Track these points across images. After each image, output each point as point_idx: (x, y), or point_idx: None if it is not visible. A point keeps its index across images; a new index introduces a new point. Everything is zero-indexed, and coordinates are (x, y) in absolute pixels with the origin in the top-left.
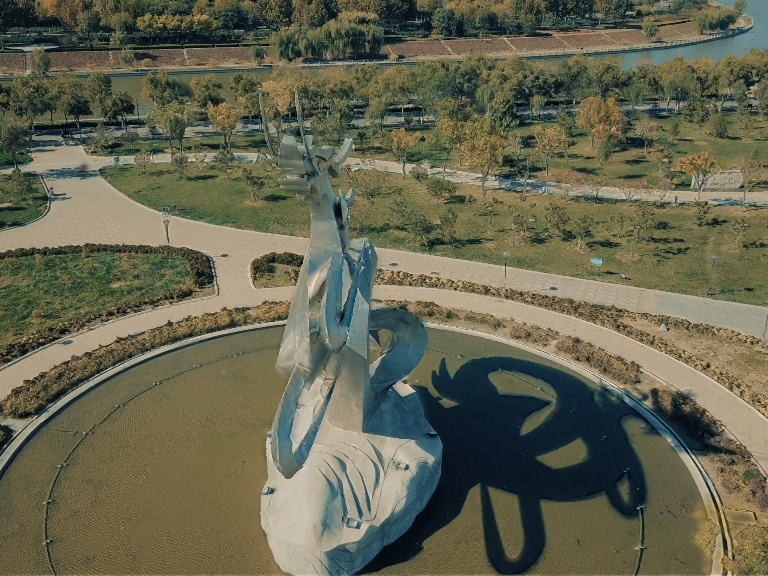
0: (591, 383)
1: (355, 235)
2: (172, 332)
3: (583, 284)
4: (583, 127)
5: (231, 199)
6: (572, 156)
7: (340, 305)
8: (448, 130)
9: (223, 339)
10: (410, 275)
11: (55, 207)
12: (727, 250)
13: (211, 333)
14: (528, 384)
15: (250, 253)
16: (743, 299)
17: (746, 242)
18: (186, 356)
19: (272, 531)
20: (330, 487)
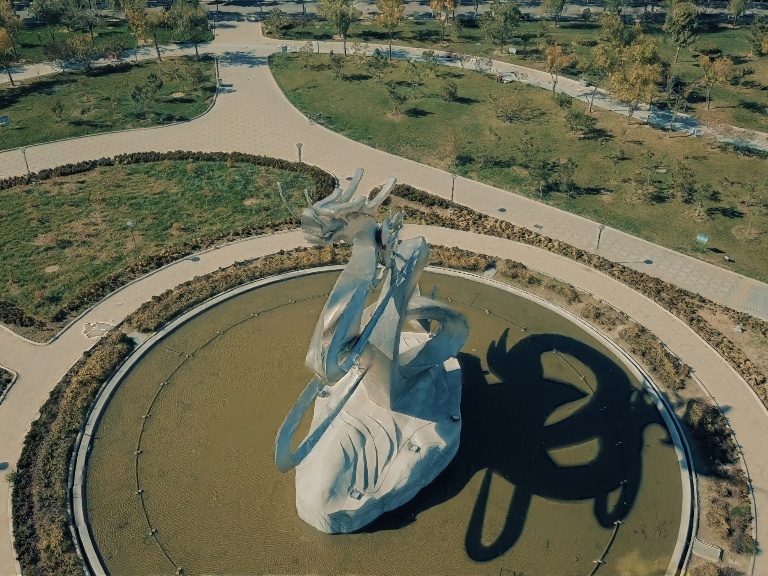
0: (635, 381)
1: (477, 169)
2: (280, 263)
3: (681, 261)
4: (767, 52)
5: (375, 109)
6: (748, 84)
7: (358, 330)
8: (601, 58)
9: (322, 275)
10: (512, 227)
11: (220, 101)
12: None
13: (313, 268)
14: (574, 371)
15: (374, 179)
16: None
17: None
18: (286, 289)
19: (296, 485)
20: (345, 460)
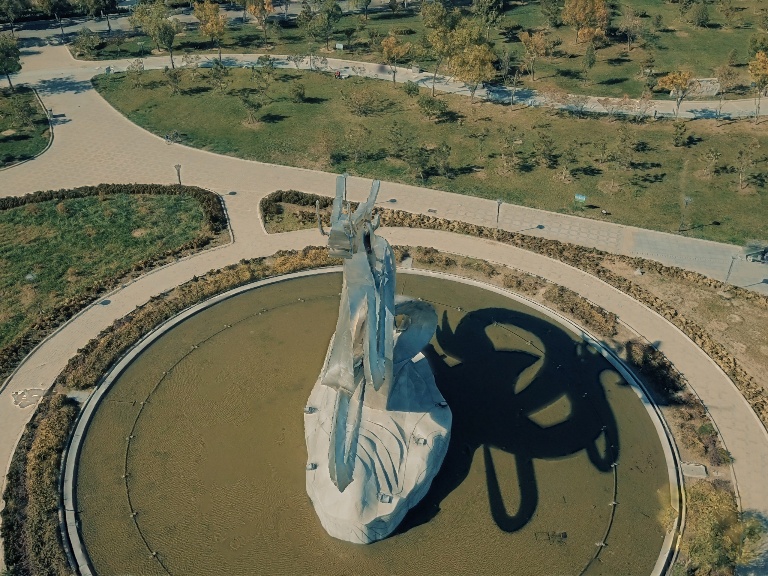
0: (575, 336)
1: (354, 165)
2: (200, 290)
3: (567, 221)
4: (568, 23)
5: (229, 120)
6: (557, 54)
7: None
8: (438, 44)
9: (246, 294)
10: (409, 215)
11: (58, 133)
12: (700, 177)
13: (235, 289)
14: (520, 338)
15: (257, 190)
16: (711, 235)
17: (718, 166)
18: (216, 315)
19: (320, 505)
20: (365, 468)
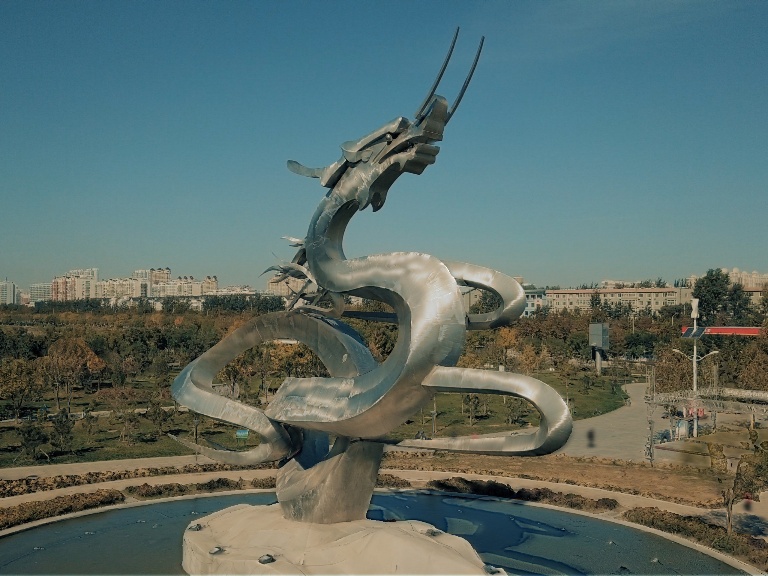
0: (382, 493)
1: None
2: None
3: None
4: None
5: None
6: None
7: None
8: None
9: None
10: (76, 476)
11: None
12: None
13: None
14: None
15: None
16: None
17: None
18: None
19: None
20: None
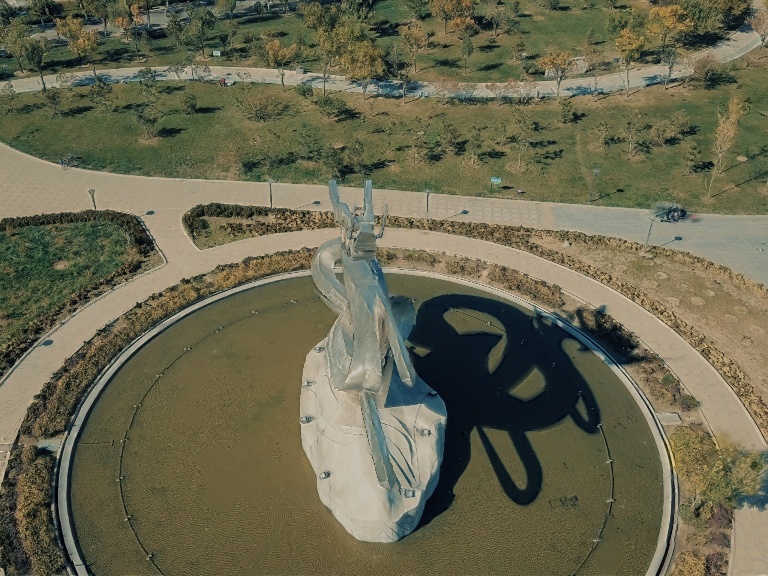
0: (528, 311)
1: (267, 171)
2: (149, 316)
3: (488, 203)
4: (437, 15)
5: (124, 138)
6: (430, 45)
7: None
8: (327, 44)
9: (197, 314)
10: None
11: None
12: (594, 149)
13: (184, 310)
14: (479, 320)
15: (175, 207)
16: (619, 202)
17: (606, 138)
18: (171, 339)
19: (344, 511)
20: None
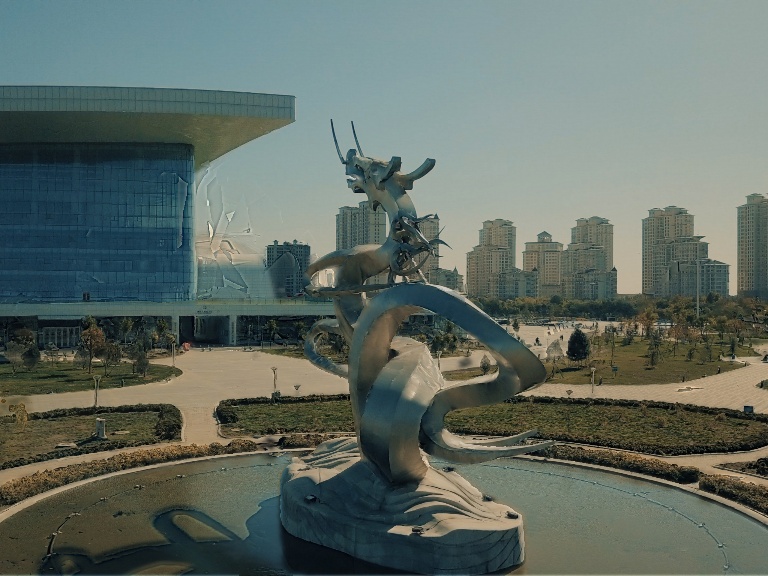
0: None
1: None
2: None
3: None
4: None
5: None
6: None
7: None
8: None
9: None
10: None
11: None
12: None
13: None
14: None
15: None
16: None
17: None
18: (767, 551)
19: None
20: None
